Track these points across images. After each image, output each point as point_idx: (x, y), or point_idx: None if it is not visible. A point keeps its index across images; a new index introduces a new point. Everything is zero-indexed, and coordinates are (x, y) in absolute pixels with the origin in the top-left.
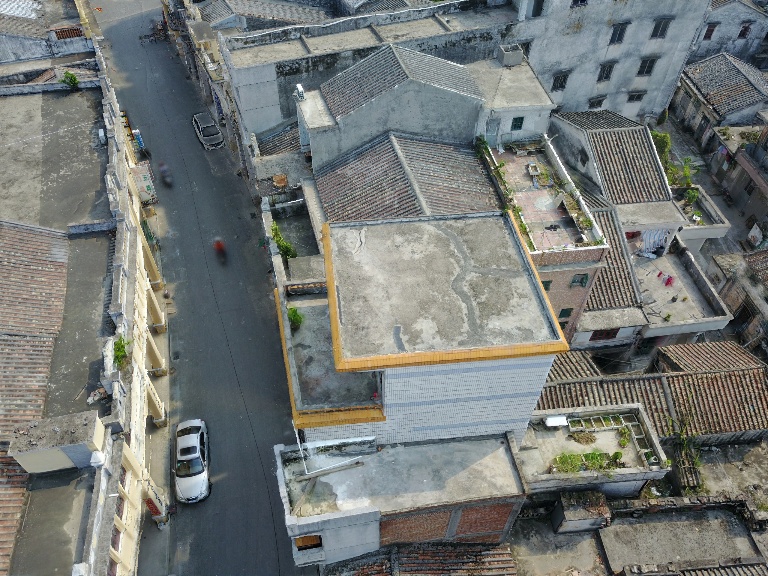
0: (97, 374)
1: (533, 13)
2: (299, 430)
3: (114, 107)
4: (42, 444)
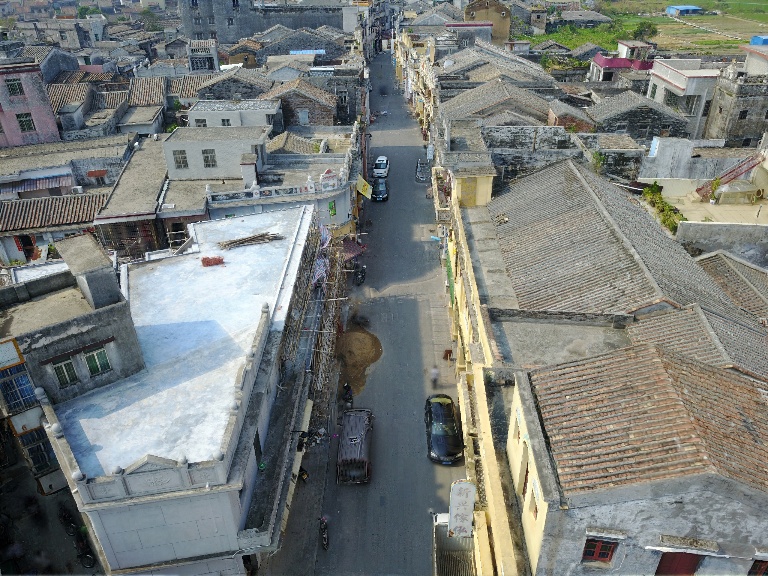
0: None
1: None
2: None
3: None
4: None
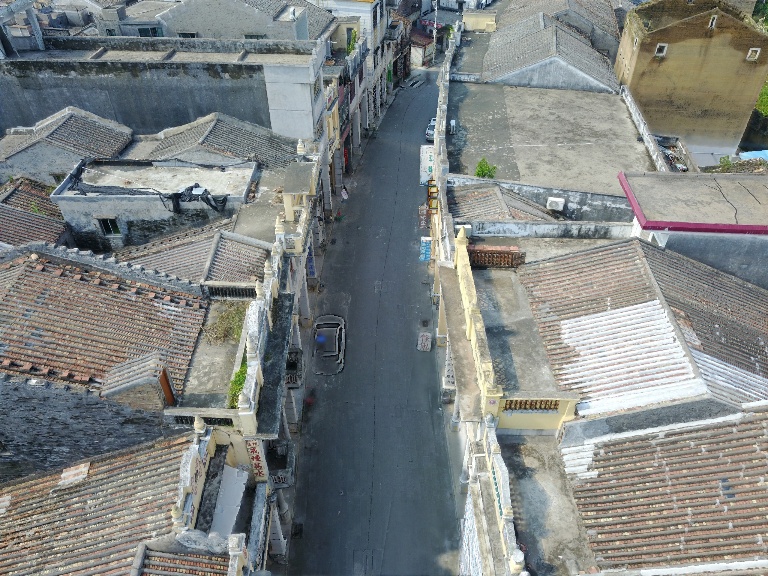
0: None
1: (5, 48)
2: None
3: (439, 162)
4: None
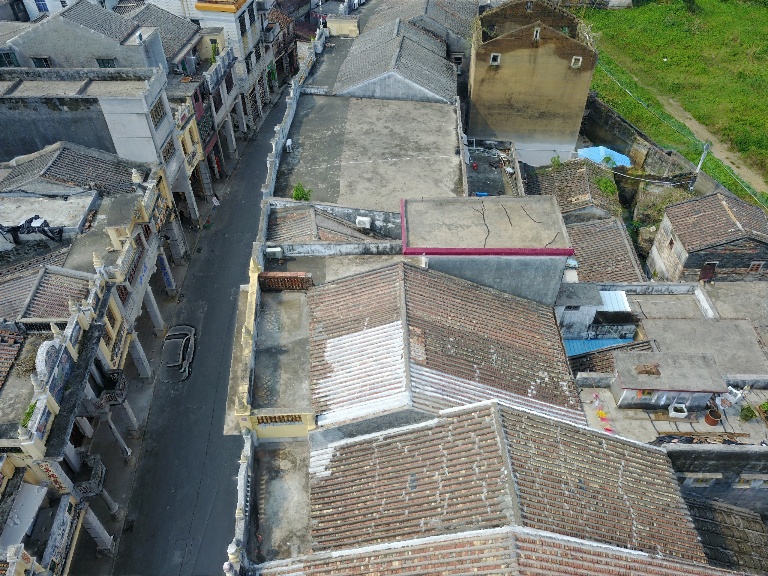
0: (329, 50)
1: None
2: (257, 134)
3: None
4: (347, 15)
